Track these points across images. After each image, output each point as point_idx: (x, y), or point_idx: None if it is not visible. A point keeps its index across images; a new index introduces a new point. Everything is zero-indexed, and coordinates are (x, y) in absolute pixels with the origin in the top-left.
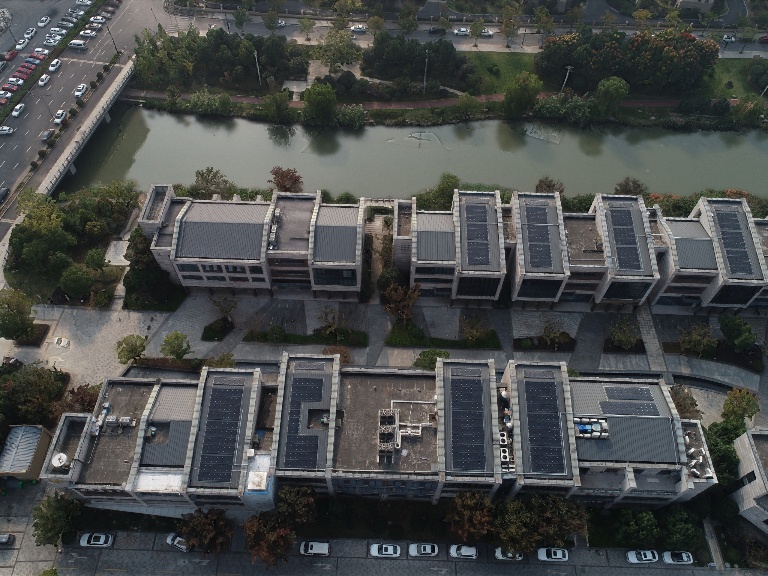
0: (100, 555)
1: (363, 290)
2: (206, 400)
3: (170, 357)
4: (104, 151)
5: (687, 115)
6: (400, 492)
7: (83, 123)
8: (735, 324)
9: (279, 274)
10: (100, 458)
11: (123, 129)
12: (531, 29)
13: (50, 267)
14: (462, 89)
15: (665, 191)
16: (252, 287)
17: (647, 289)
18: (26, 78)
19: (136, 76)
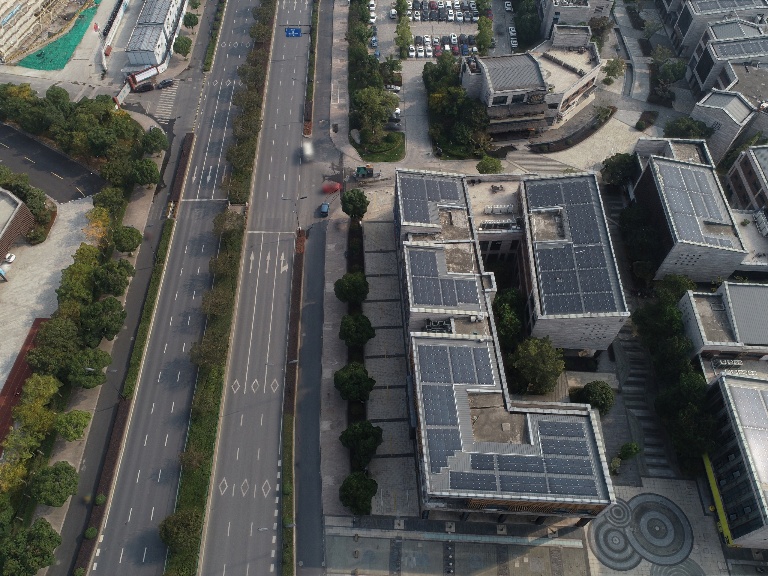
0: None
1: None
2: None
3: None
4: None
5: None
6: None
7: None
8: None
9: None
10: None
11: None
12: None
13: None
14: None
15: None
16: None
17: None
18: None
19: None
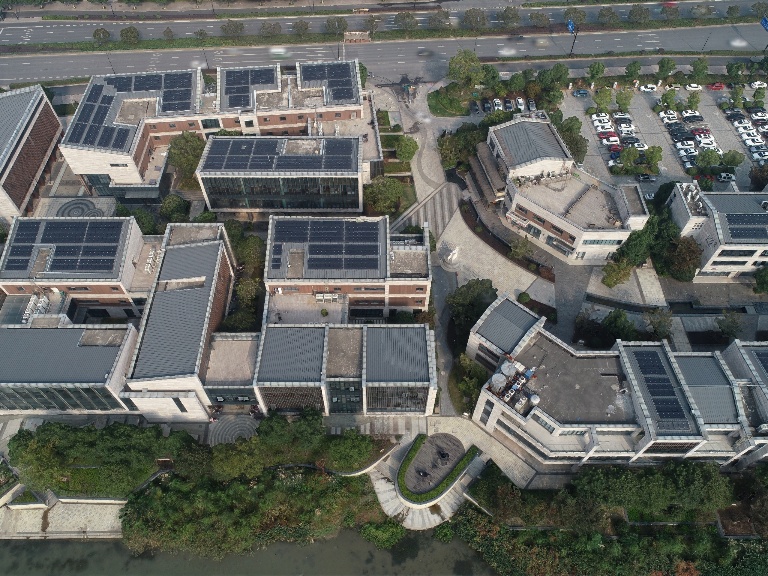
0: None
1: None
2: None
3: None
4: None
5: None
6: None
7: None
8: None
9: None
10: None
11: None
12: None
13: None
14: None
15: None
16: None
17: None
18: None
19: None
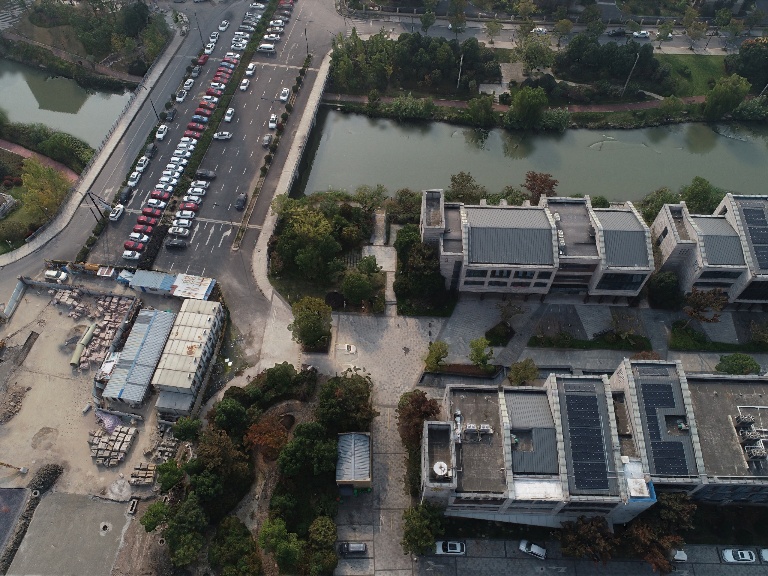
0: (456, 563)
1: (638, 294)
2: (562, 407)
3: (461, 363)
4: (310, 155)
5: None
6: (754, 497)
7: (297, 128)
8: None
9: (556, 279)
10: (469, 466)
11: (328, 133)
12: (708, 31)
13: (315, 273)
14: (658, 92)
15: None
16: (529, 292)
17: None
18: (226, 83)
19: (330, 80)
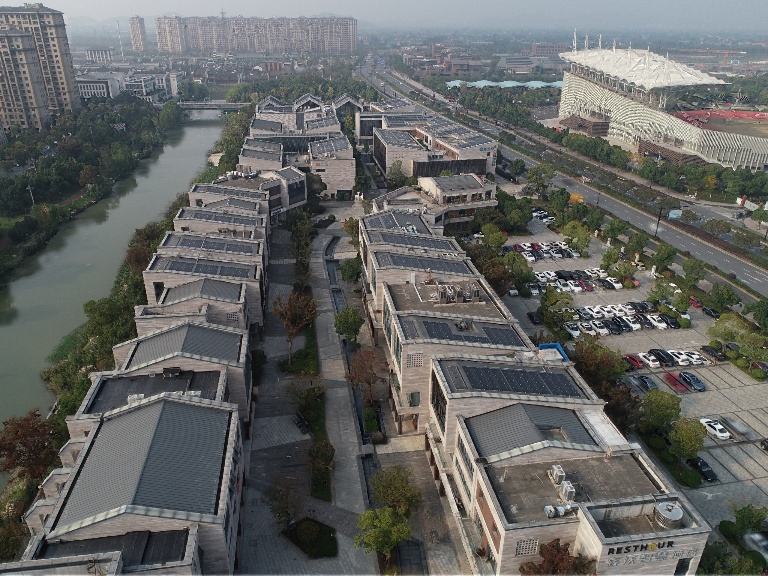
0: None
1: None
2: None
3: None
4: None
5: (27, 239)
6: None
7: None
8: (293, 218)
9: None
10: (624, 494)
11: None
12: None
13: None
14: None
15: (120, 259)
16: None
17: None
18: None
19: None
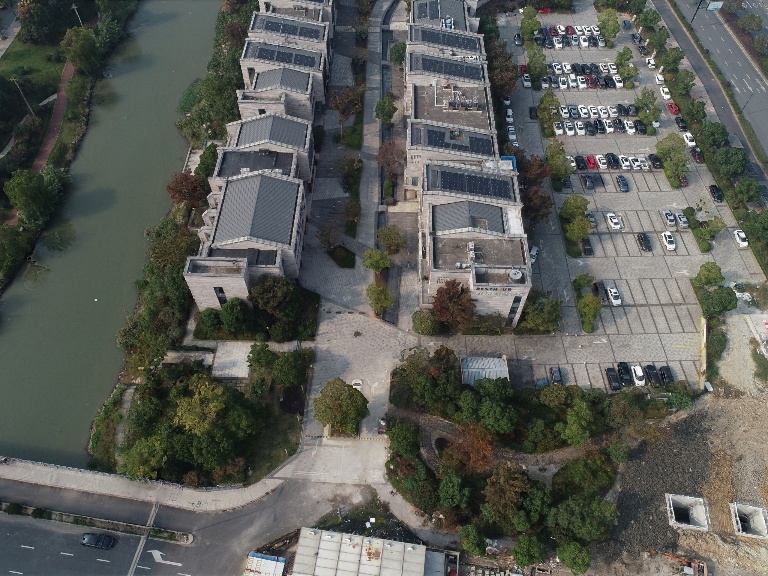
0: None
1: None
2: None
3: None
4: None
5: None
6: None
7: None
8: None
9: None
10: (503, 262)
11: None
12: None
13: None
14: (45, 96)
15: (215, 9)
16: None
17: (333, 4)
18: None
19: None
